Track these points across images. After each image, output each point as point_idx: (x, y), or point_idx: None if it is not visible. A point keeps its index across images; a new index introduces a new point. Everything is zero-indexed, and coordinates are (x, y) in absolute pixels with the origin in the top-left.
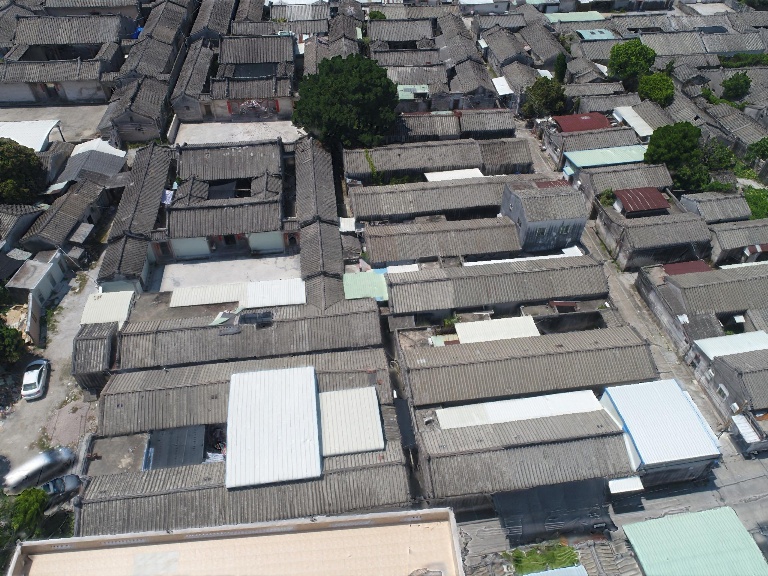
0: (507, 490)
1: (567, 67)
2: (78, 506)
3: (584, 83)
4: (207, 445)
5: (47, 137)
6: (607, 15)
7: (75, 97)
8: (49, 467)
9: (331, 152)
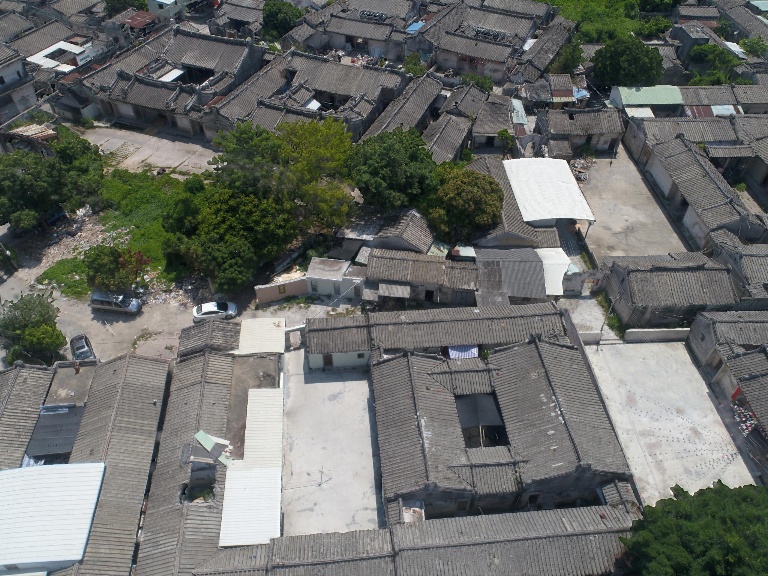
0: None
1: None
2: None
3: None
4: (51, 458)
5: (557, 220)
6: None
7: (688, 224)
8: (118, 346)
9: (626, 573)
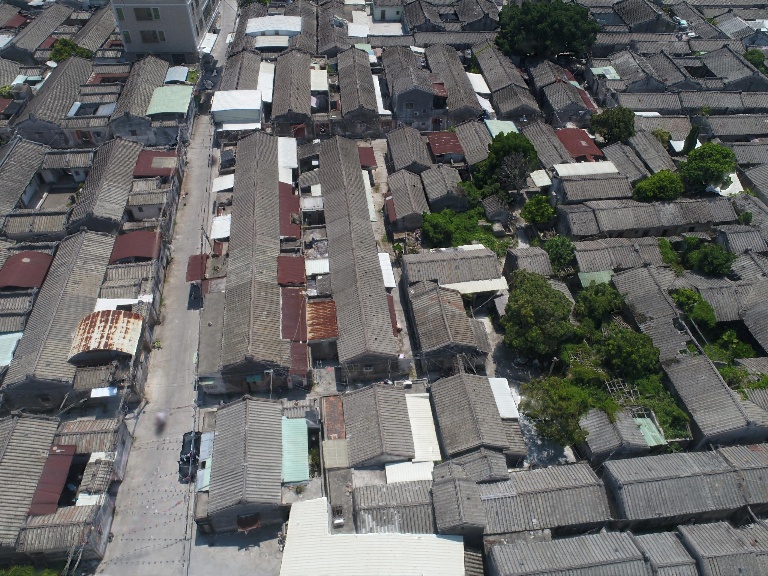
0: (223, 69)
1: None
2: (253, 2)
3: None
4: None
5: None
6: None
7: None
8: None
9: None
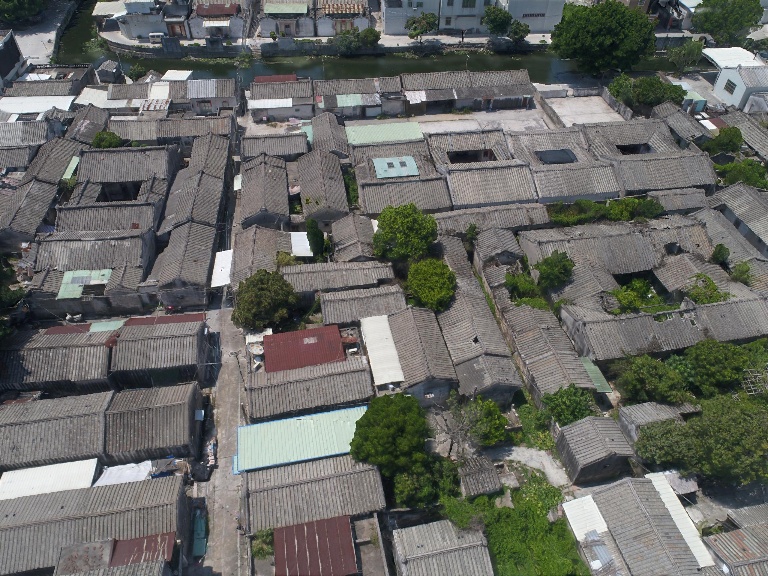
0: None
1: (332, 229)
2: None
3: (341, 263)
4: None
5: None
6: (445, 118)
7: None
8: None
9: None
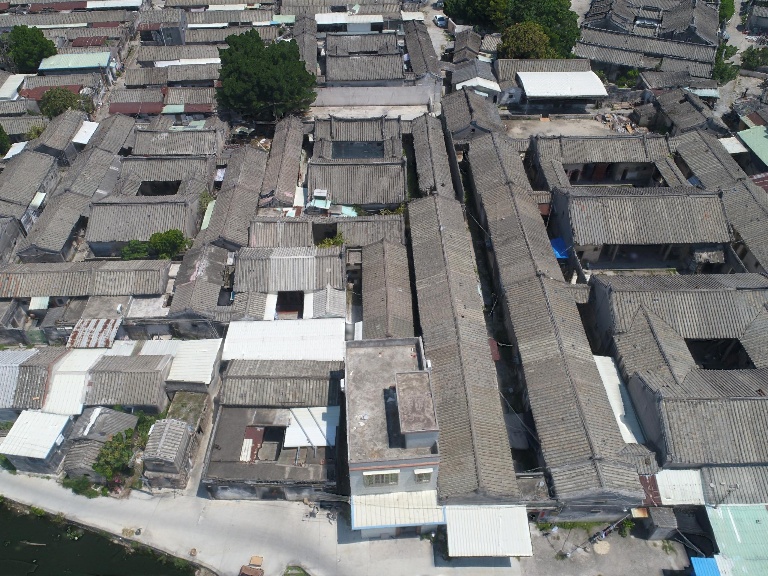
0: None
1: None
2: None
3: None
4: None
5: None
6: None
7: None
8: None
9: None
